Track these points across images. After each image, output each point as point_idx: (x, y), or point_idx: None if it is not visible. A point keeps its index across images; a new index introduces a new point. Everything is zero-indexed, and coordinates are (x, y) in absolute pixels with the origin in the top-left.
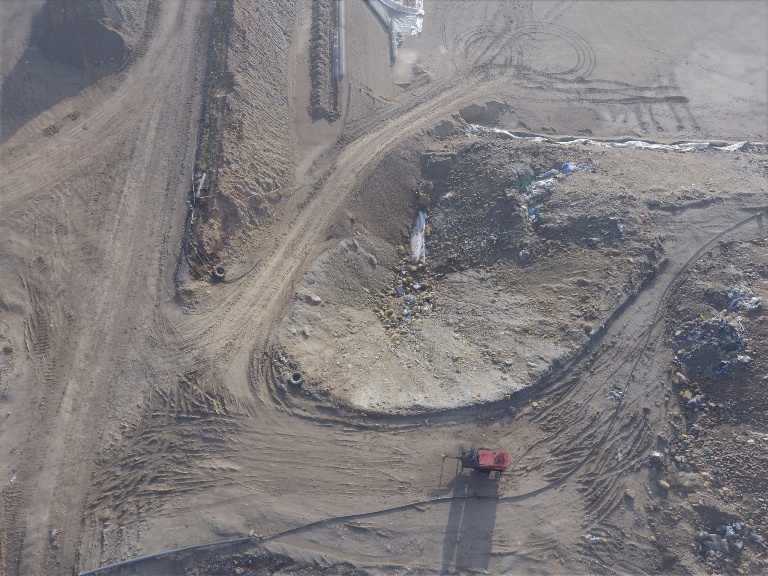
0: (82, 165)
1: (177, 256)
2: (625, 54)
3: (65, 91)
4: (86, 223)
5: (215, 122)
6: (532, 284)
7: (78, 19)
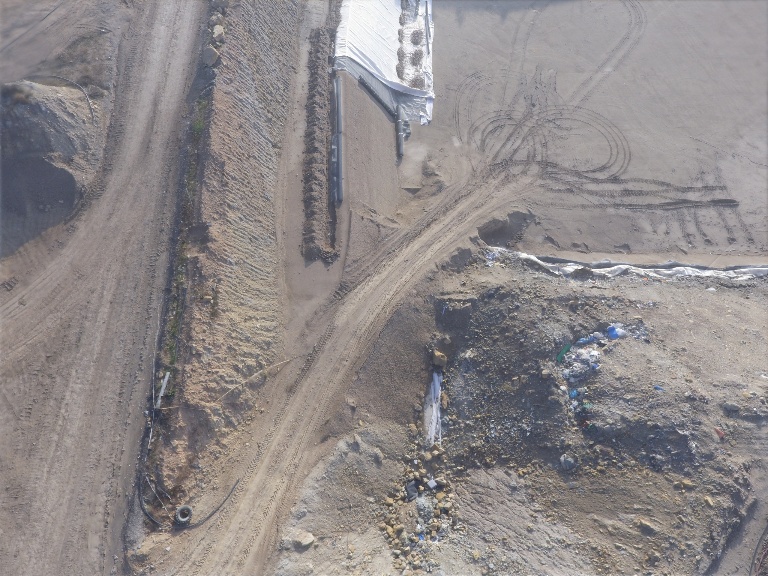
0: (15, 358)
1: (128, 499)
2: (663, 145)
3: (1, 248)
4: (14, 448)
5: (183, 294)
6: (579, 511)
7: (19, 156)
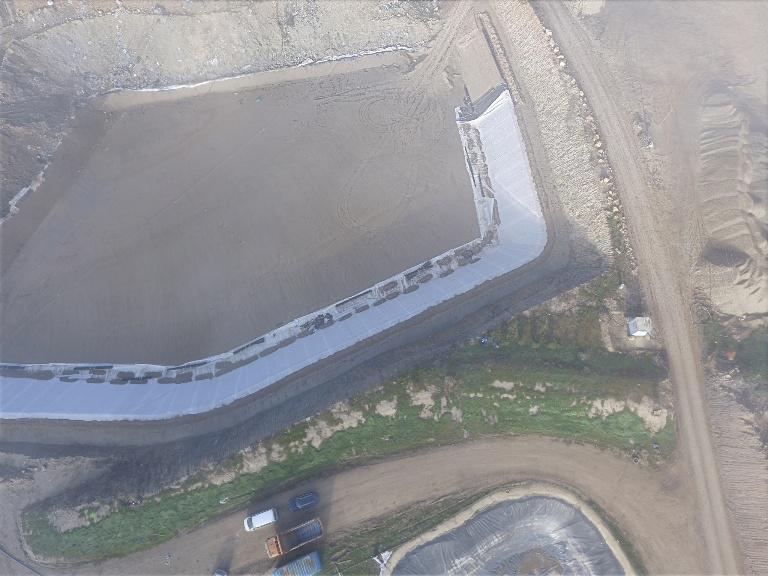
0: None
1: None
2: (342, 121)
3: None
4: None
5: None
6: None
7: None
